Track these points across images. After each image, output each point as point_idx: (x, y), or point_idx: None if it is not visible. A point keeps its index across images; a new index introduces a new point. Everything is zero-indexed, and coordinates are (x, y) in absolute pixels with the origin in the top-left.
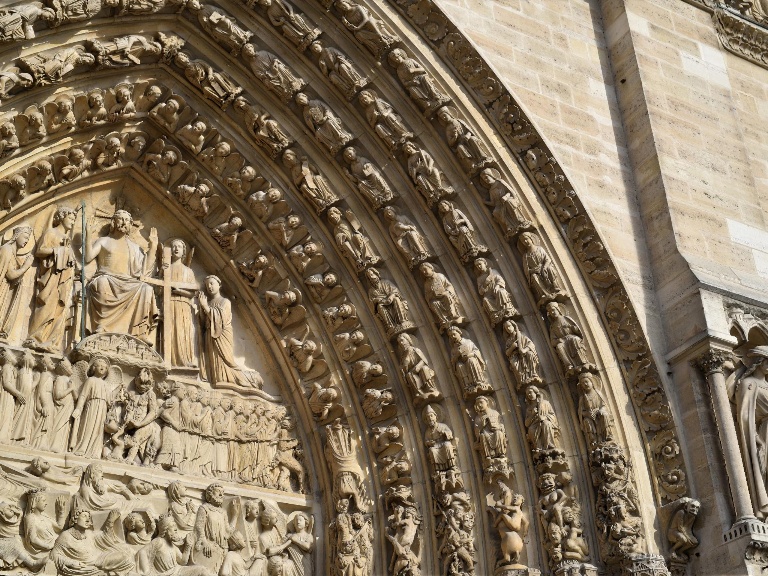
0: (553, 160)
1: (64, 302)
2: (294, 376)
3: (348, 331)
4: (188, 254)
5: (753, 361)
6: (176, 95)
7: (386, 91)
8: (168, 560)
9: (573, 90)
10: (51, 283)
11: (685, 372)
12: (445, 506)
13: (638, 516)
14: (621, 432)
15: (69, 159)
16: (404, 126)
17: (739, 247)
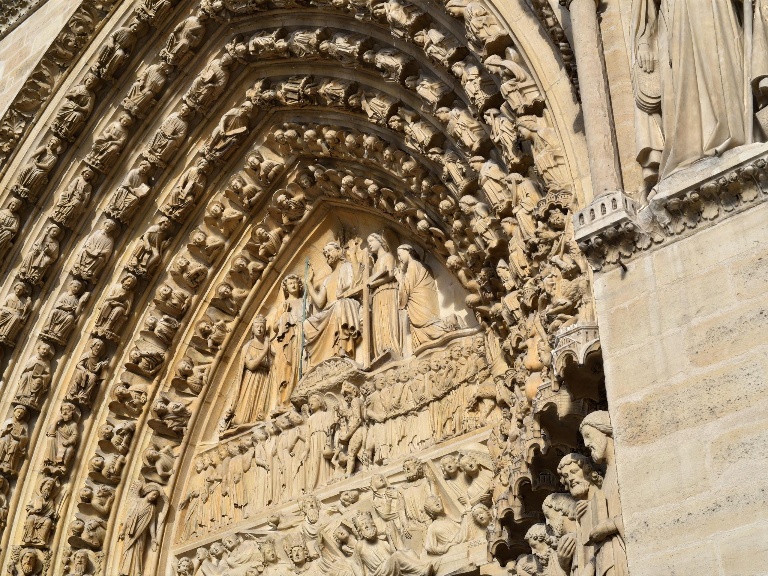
0: None
1: (291, 361)
2: None
3: None
4: None
5: None
6: (289, 125)
7: None
8: (373, 559)
9: None
10: (279, 352)
11: None
12: None
13: (581, 275)
14: None
15: None
16: None
17: None
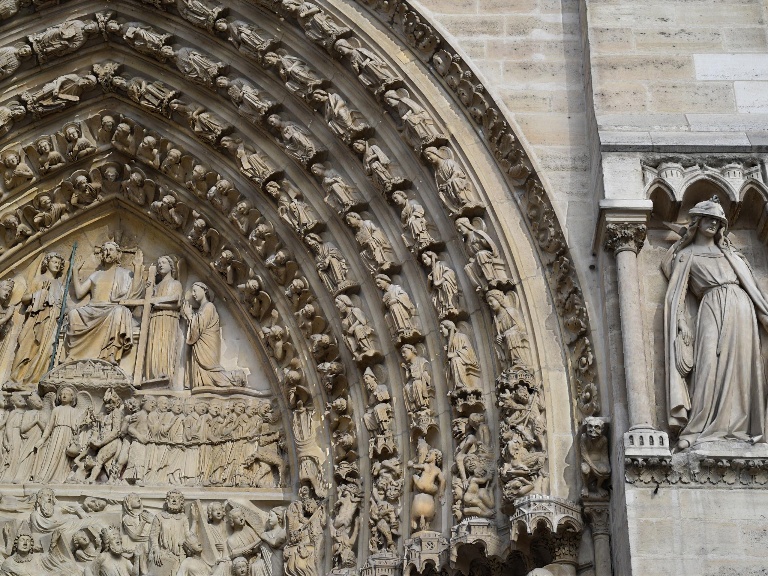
0: (456, 57)
1: (40, 341)
2: (273, 366)
3: None
4: None
5: None
6: (125, 118)
7: (294, 45)
8: (113, 573)
9: None
10: (27, 326)
11: None
12: (374, 476)
13: (541, 451)
14: (535, 352)
15: (40, 208)
16: (313, 75)
17: (709, 85)
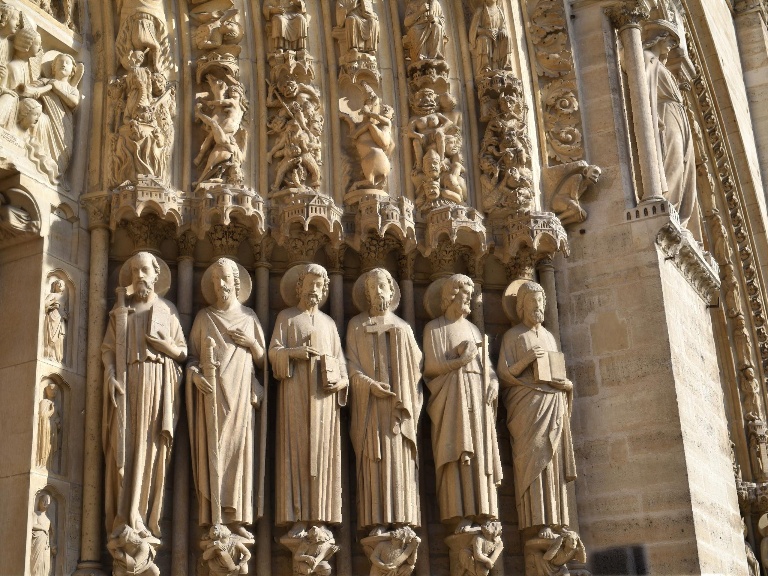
0: None
1: None
2: None
3: None
4: None
5: (656, 33)
6: None
7: None
8: None
9: None
10: None
11: (595, 19)
12: (289, 96)
13: (530, 169)
14: (516, 66)
15: None
16: None
17: None
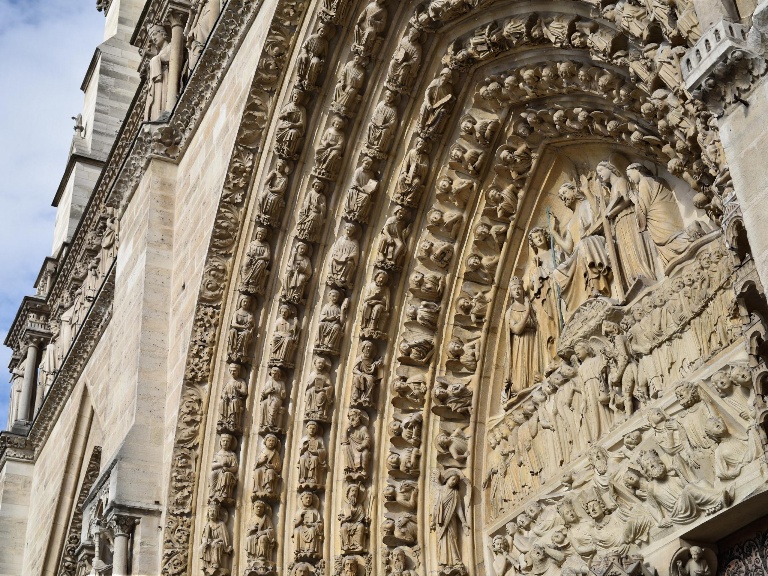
0: None
1: (552, 315)
2: None
3: None
4: None
5: None
6: (490, 79)
7: None
8: (667, 498)
9: None
10: (539, 309)
11: None
12: None
13: None
14: None
15: None
16: None
17: None
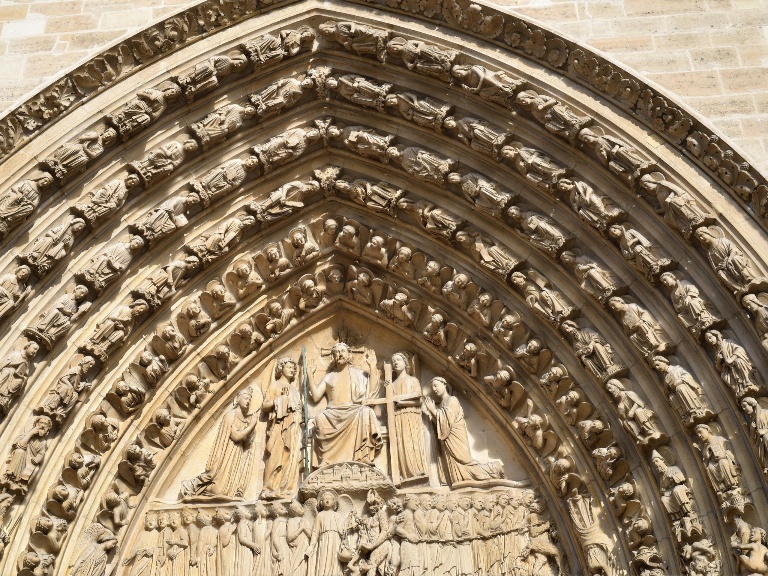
0: (714, 138)
1: (289, 447)
2: (532, 455)
3: (565, 394)
4: (411, 364)
5: None
6: (349, 220)
7: (529, 137)
8: None
9: (739, 49)
10: (275, 433)
11: None
12: (686, 560)
13: None
14: None
15: (271, 314)
16: (555, 165)
17: None
